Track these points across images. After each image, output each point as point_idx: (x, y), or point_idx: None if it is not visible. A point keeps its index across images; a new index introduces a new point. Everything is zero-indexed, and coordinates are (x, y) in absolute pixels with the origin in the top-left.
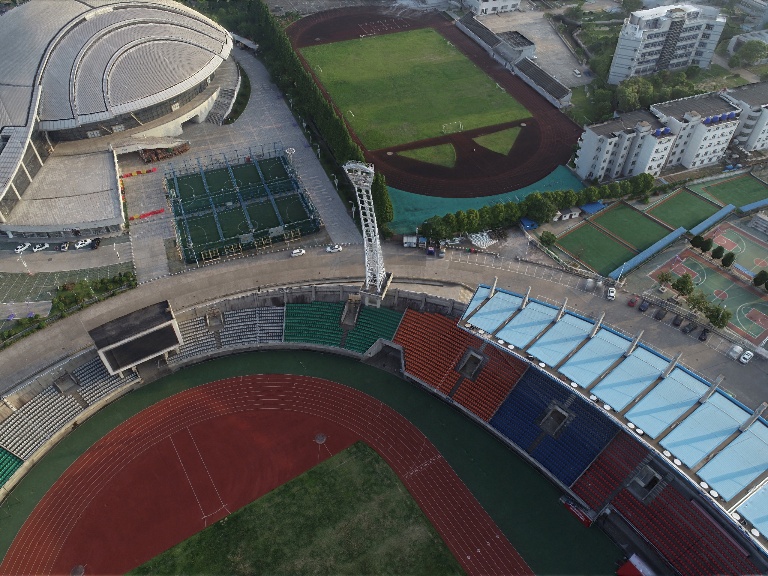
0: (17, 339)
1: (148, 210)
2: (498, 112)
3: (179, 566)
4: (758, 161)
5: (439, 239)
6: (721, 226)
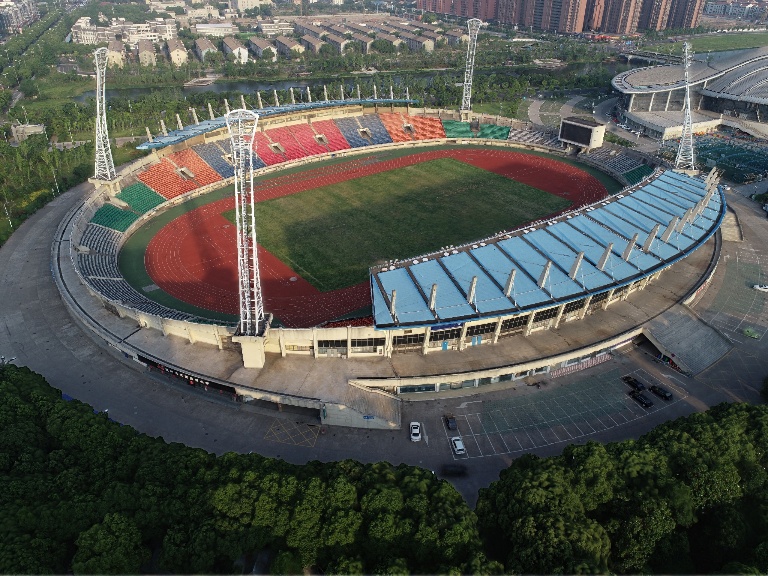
0: None
1: None
2: None
3: None
4: None
5: None
6: None
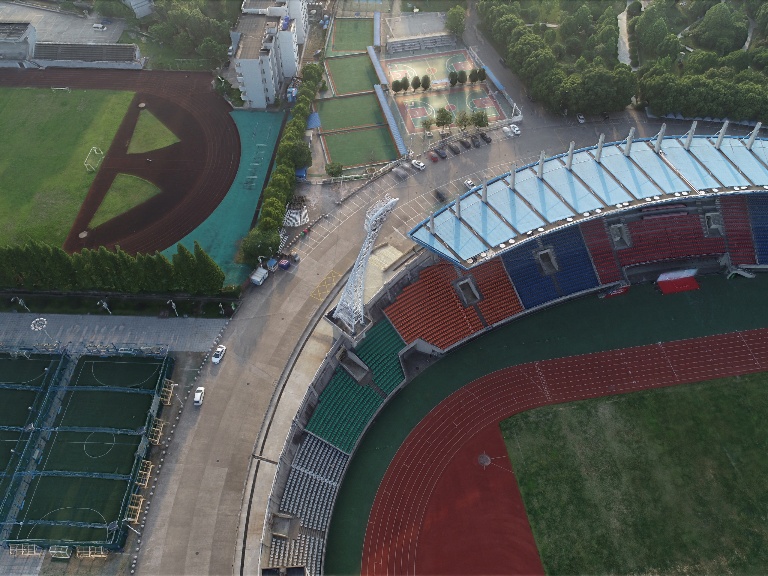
0: None
1: None
2: (101, 112)
3: None
4: (331, 5)
5: (277, 249)
6: (381, 66)
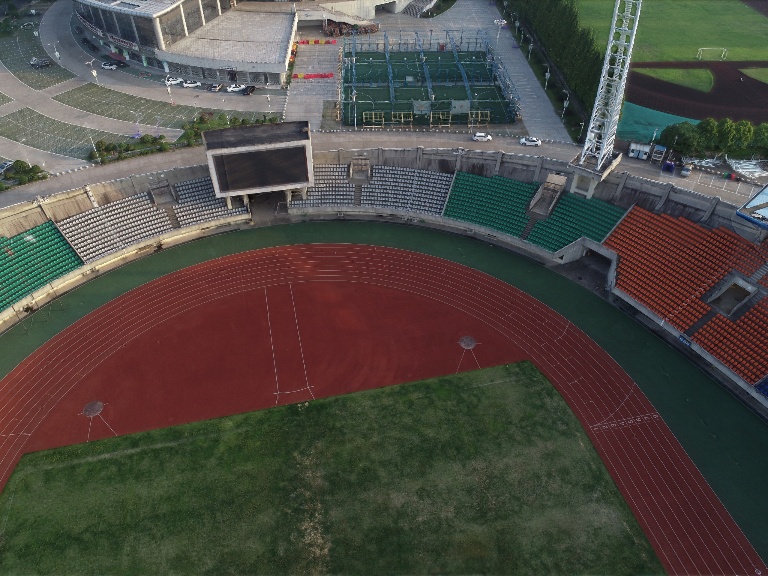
0: (134, 155)
1: (315, 73)
2: None
3: (223, 444)
4: None
5: (684, 153)
6: None
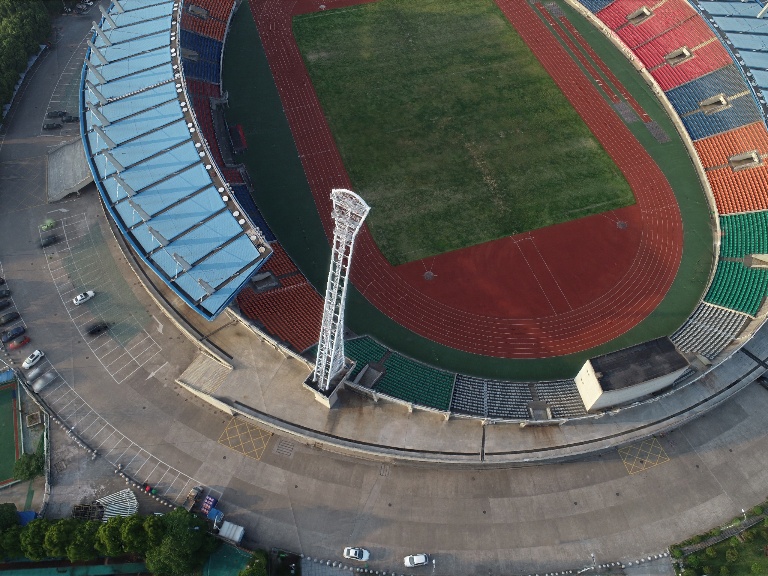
0: None
1: None
2: None
3: (546, 212)
4: None
5: None
6: None
